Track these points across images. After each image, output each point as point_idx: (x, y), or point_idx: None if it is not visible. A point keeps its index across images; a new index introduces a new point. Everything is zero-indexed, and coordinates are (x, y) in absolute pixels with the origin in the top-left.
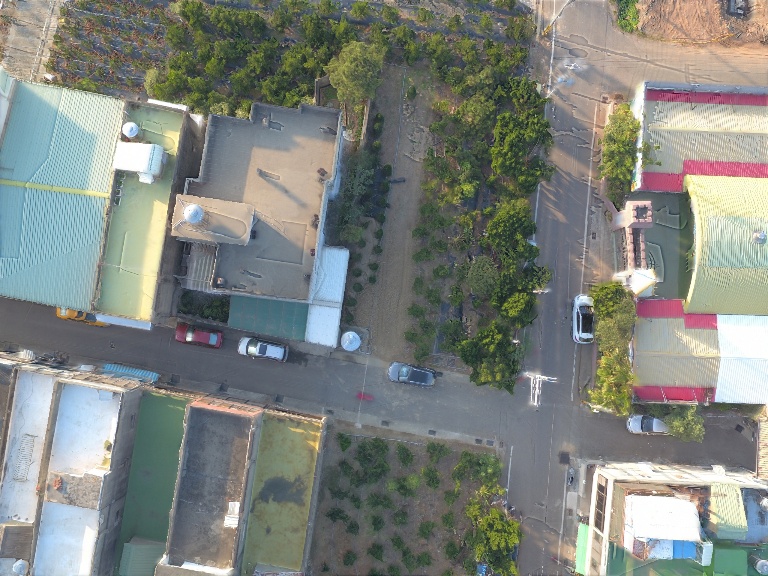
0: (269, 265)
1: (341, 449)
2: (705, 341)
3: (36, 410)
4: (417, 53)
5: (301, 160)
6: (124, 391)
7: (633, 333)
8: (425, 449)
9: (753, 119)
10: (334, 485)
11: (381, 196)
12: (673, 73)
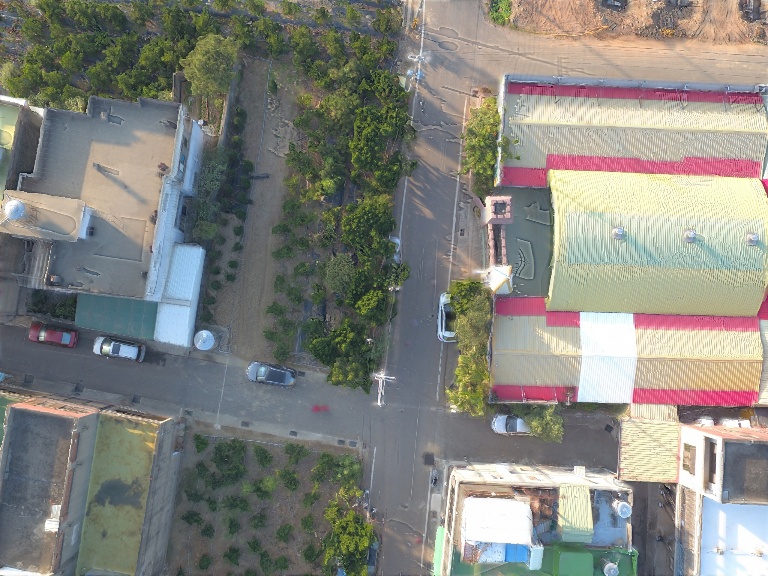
0: (107, 262)
1: None
2: (566, 339)
3: None
4: (280, 46)
5: (141, 155)
6: None
7: (490, 331)
8: (285, 450)
9: (618, 112)
10: (191, 487)
11: (244, 192)
12: (545, 66)
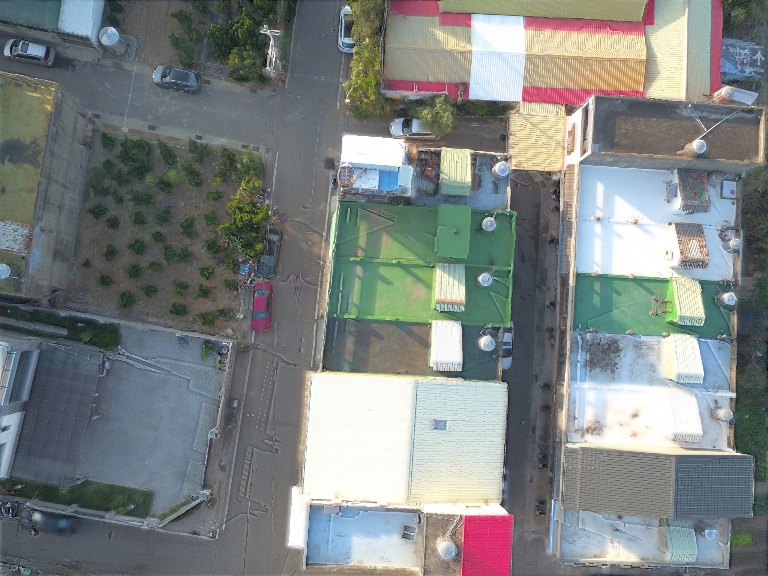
0: None
1: (106, 151)
2: (458, 36)
3: None
4: None
5: None
6: None
7: (382, 22)
8: None
9: None
10: (99, 186)
11: None
12: None
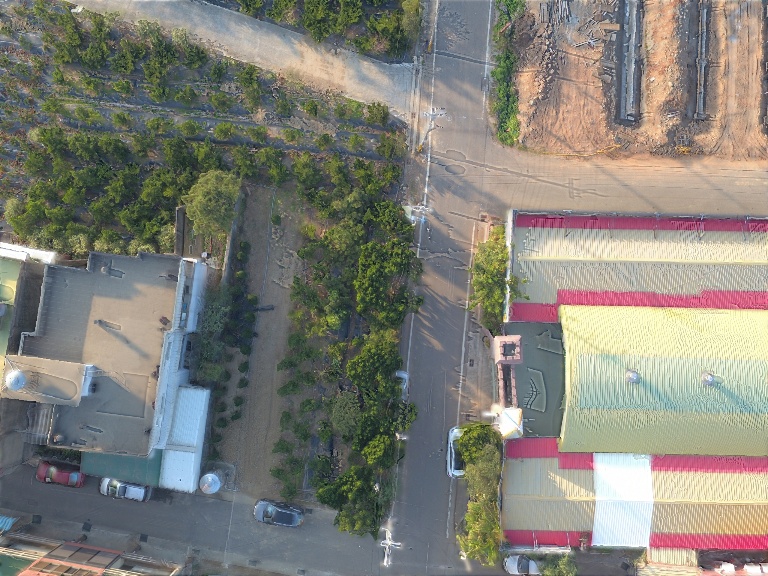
0: (110, 419)
1: None
2: (579, 482)
3: None
4: (283, 176)
5: (143, 309)
6: None
7: (499, 478)
8: None
9: (631, 245)
10: None
11: (248, 325)
12: (556, 188)
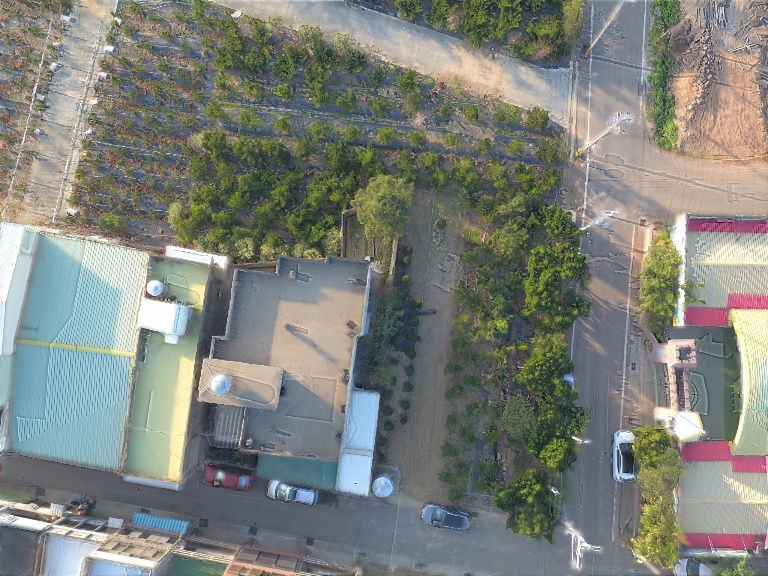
0: (298, 423)
1: None
2: (754, 486)
3: (64, 575)
4: (446, 181)
5: (330, 312)
6: (152, 566)
7: (678, 481)
8: None
9: None
10: None
11: (411, 329)
12: (714, 193)
